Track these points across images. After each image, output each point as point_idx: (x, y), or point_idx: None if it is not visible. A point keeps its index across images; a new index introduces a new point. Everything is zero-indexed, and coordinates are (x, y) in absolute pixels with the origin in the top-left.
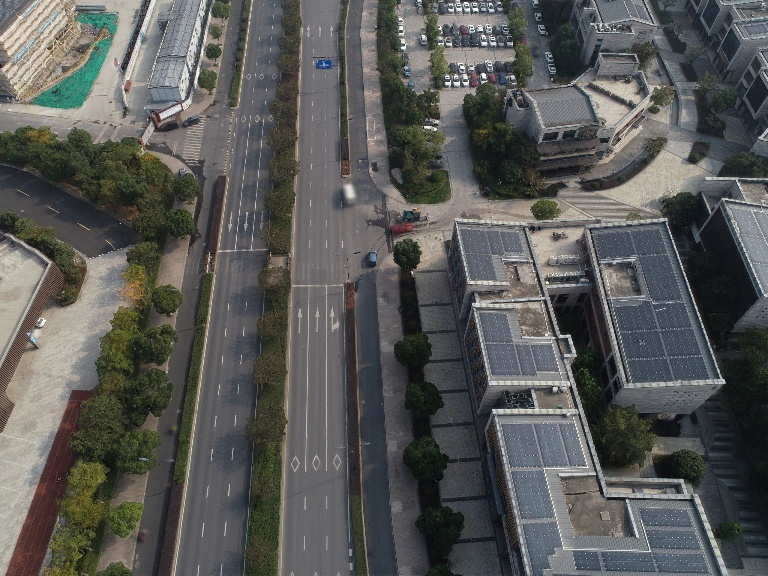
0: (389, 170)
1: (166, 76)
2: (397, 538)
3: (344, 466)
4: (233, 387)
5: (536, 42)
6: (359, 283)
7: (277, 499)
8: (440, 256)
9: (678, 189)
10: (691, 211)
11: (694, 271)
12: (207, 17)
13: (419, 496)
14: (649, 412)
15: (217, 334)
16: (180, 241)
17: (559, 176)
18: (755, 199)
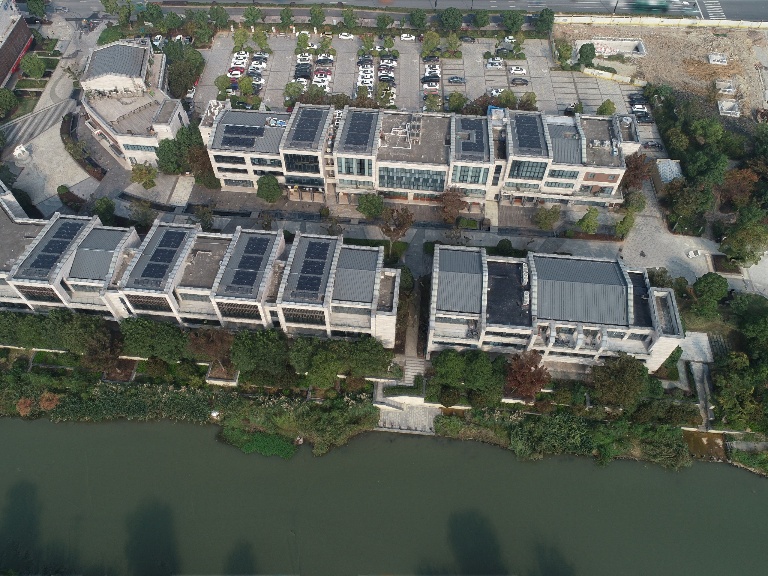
0: None
1: None
2: None
3: None
4: None
5: None
6: (48, 6)
7: None
8: None
9: (35, 172)
10: None
11: None
12: None
13: None
14: None
15: None
16: None
17: None
18: None
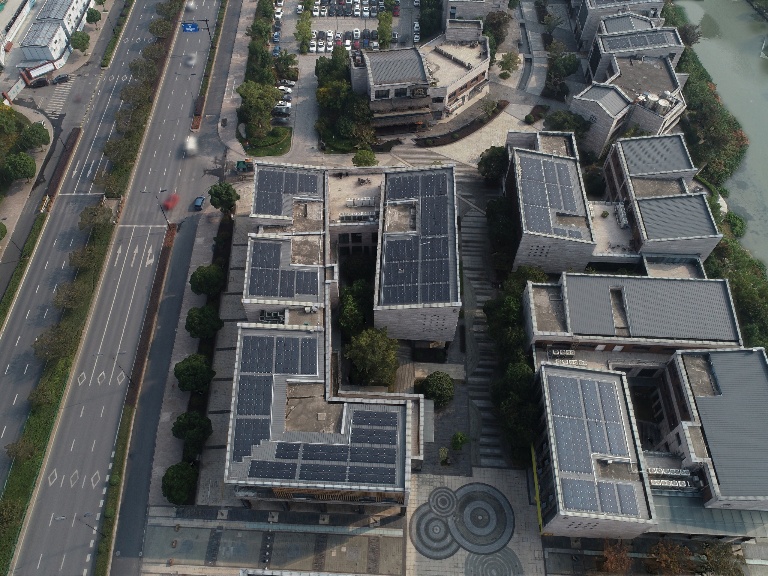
0: (237, 126)
1: (38, 36)
2: (158, 443)
3: (126, 381)
4: (41, 312)
5: (409, 13)
6: (182, 225)
7: (55, 407)
8: None
9: None
10: (498, 163)
11: (489, 216)
12: None
13: (188, 408)
14: (414, 339)
15: (38, 266)
16: (24, 185)
17: (397, 134)
18: (551, 150)
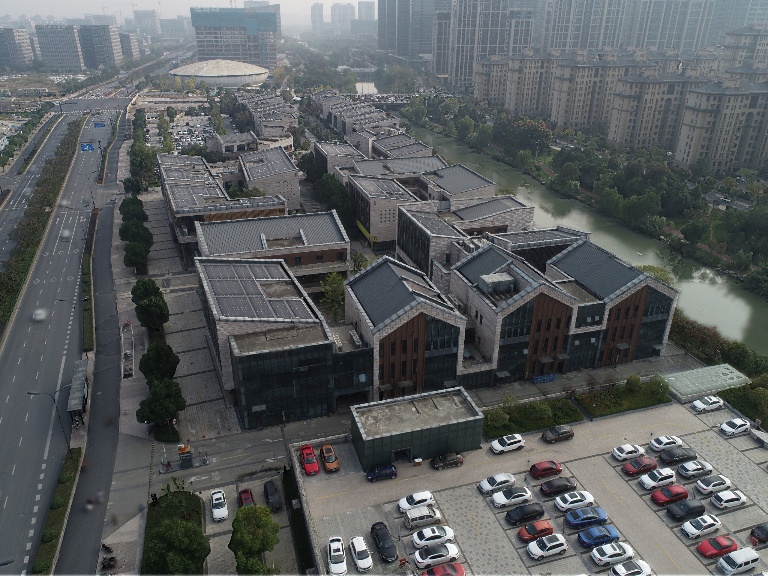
0: None
1: None
2: (113, 263)
3: (81, 251)
4: (4, 241)
5: None
6: (103, 209)
7: (30, 260)
8: (160, 197)
9: None
10: (308, 160)
11: None
12: (5, 149)
13: None
14: None
15: None
16: None
17: None
18: None
